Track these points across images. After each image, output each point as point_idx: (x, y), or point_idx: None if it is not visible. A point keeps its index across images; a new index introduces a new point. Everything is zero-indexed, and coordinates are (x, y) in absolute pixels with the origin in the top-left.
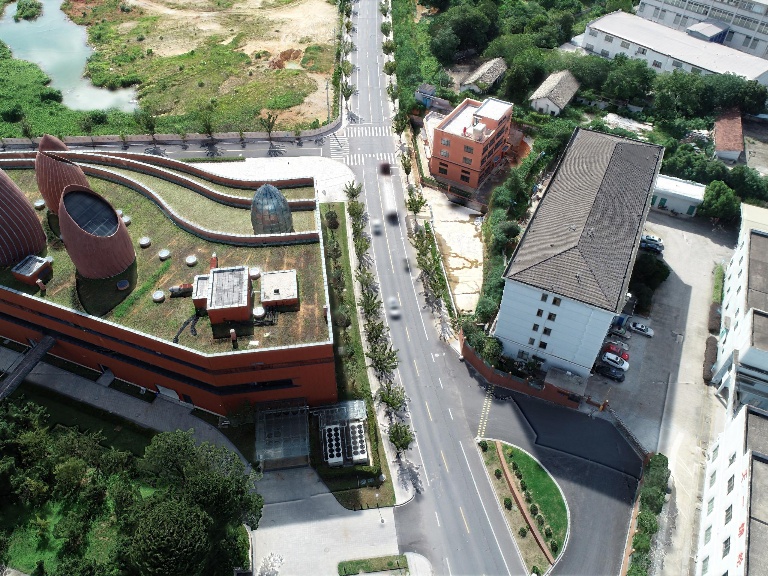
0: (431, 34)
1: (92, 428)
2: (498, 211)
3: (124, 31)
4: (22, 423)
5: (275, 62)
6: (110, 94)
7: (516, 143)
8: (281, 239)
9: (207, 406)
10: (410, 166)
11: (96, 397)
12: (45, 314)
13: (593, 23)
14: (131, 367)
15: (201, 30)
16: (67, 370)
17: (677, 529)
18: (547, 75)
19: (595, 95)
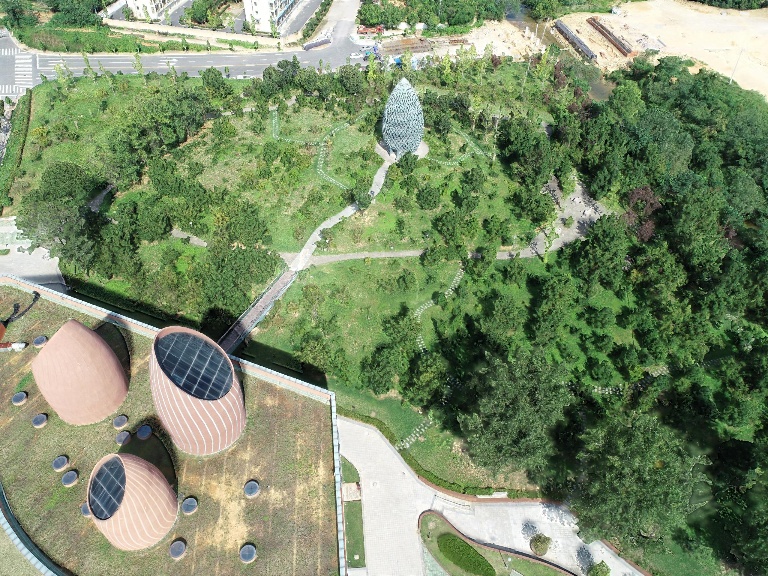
0: None
1: None
2: None
3: None
4: None
5: None
6: None
7: None
8: None
9: None
10: None
11: None
12: None
13: None
14: None
15: None
16: None
17: None
18: None
19: None
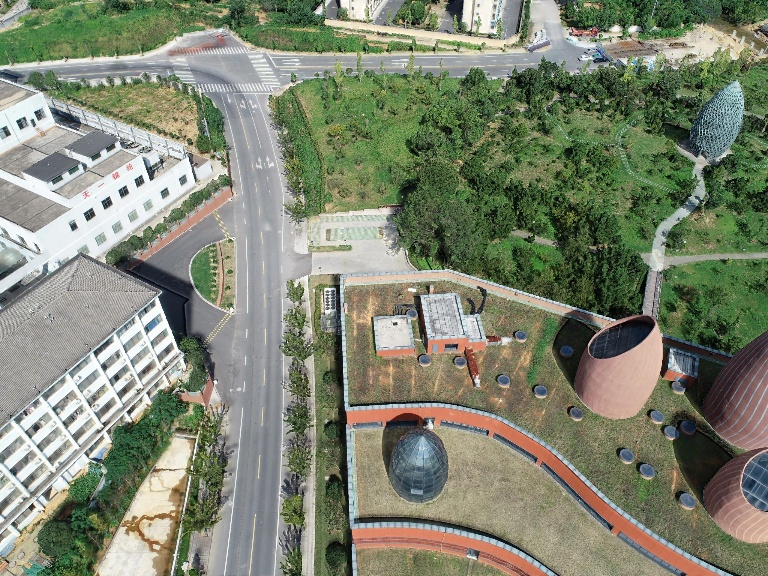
0: None
1: None
2: None
3: None
4: None
5: None
6: None
7: None
8: None
9: None
10: None
11: None
12: None
13: None
14: None
15: None
16: None
17: None
18: None
19: None
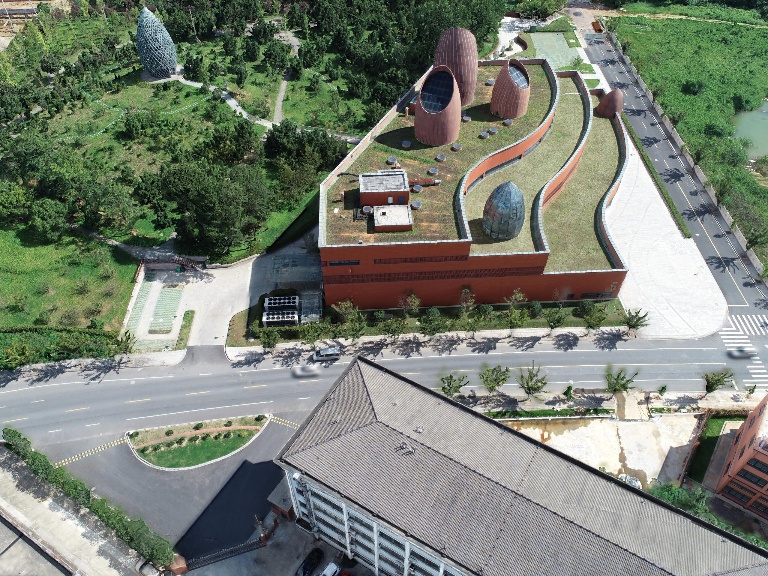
0: None
1: None
2: None
3: None
4: (325, 149)
5: None
6: None
7: None
8: None
9: None
10: (713, 384)
11: None
12: None
13: None
14: None
15: None
16: None
17: (108, 567)
18: None
19: None
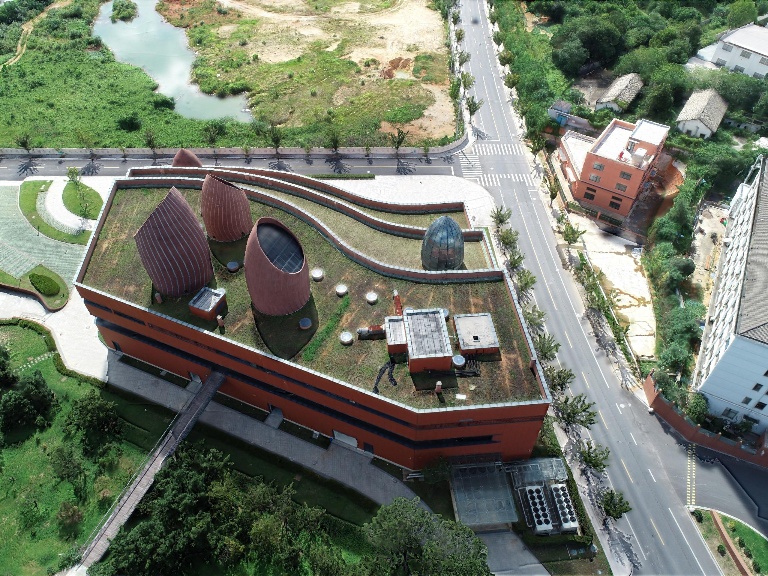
0: (554, 46)
1: (270, 476)
2: (665, 245)
3: (225, 35)
4: (208, 472)
5: (385, 71)
6: (220, 102)
7: (663, 167)
8: (462, 276)
9: (390, 456)
10: (557, 191)
11: (267, 440)
12: (223, 352)
13: (727, 37)
14: (310, 411)
15: (303, 35)
16: (232, 408)
17: None
18: (688, 93)
19: (746, 117)
